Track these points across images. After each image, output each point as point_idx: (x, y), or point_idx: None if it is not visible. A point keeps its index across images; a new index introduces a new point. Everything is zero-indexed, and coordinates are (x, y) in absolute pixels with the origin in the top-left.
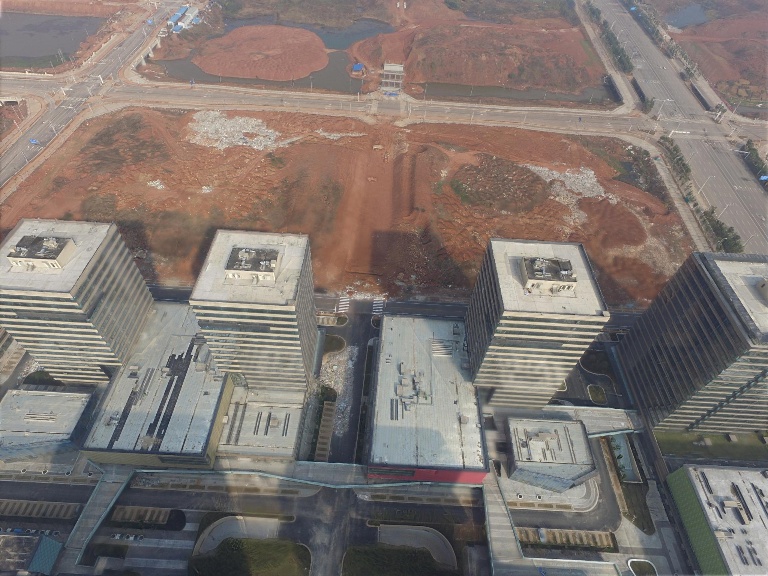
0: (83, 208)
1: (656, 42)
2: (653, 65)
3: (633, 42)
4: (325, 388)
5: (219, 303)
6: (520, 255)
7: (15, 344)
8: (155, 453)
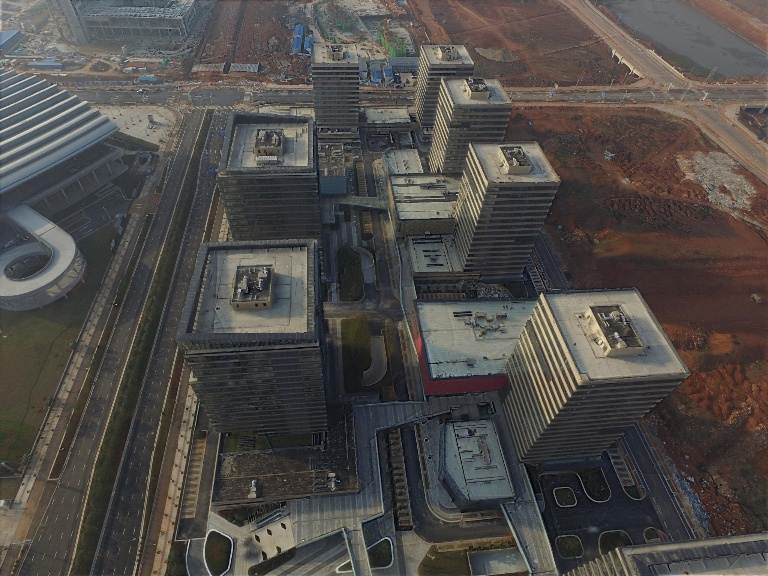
0: (559, 133)
1: None
2: None
3: None
4: (476, 291)
5: None
6: (630, 314)
7: None
8: (394, 201)
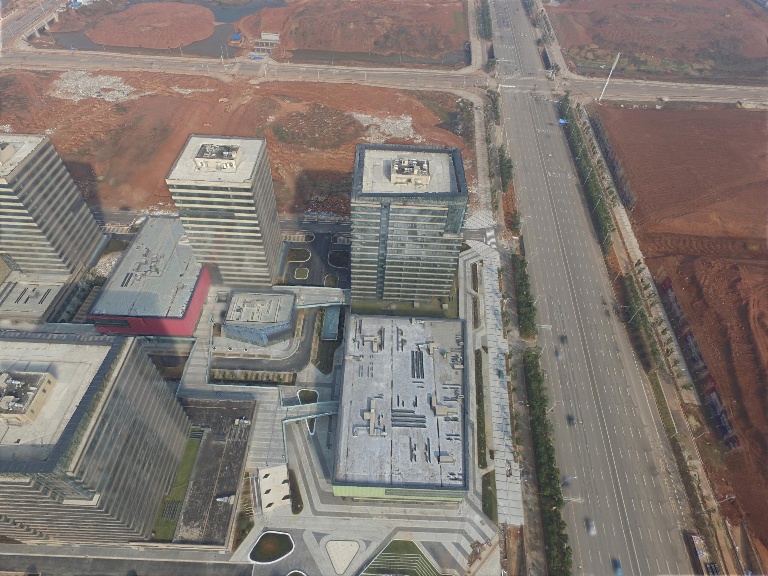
0: None
1: (529, 14)
2: (516, 33)
3: (507, 14)
4: (98, 277)
5: None
6: None
7: None
8: None
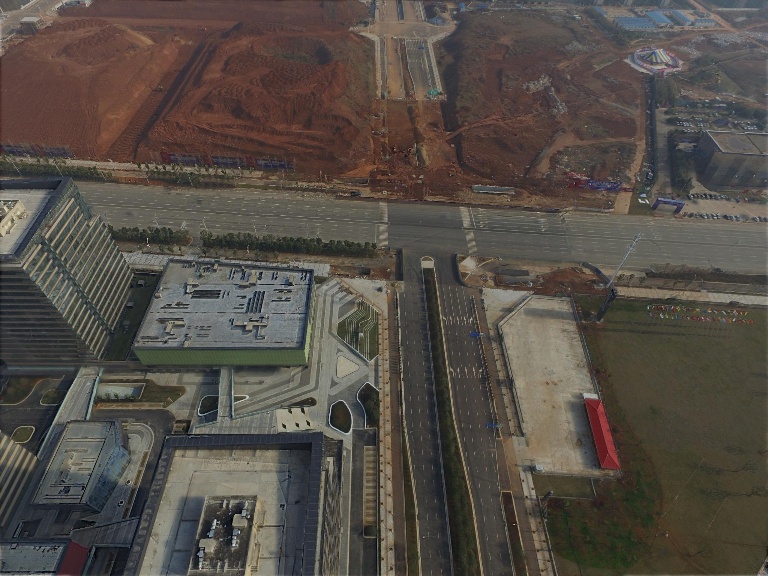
0: None
1: None
2: None
3: None
4: None
5: None
6: None
7: None
8: None
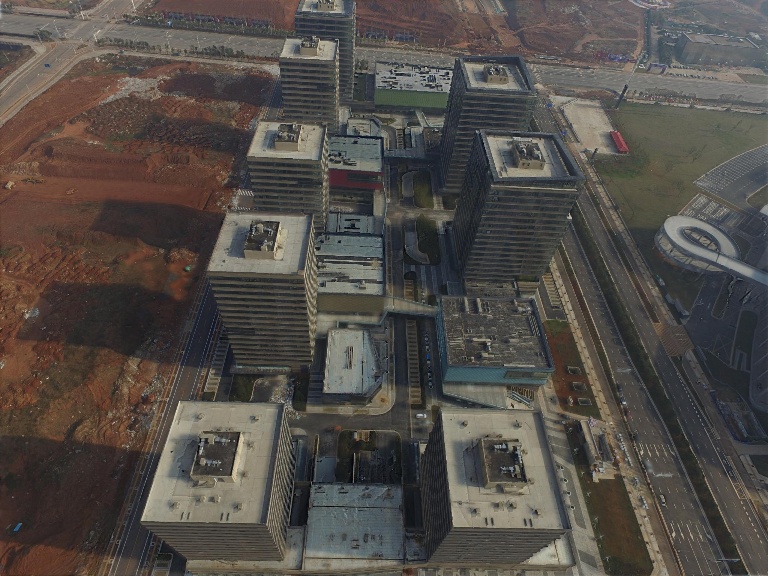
0: (5, 456)
1: None
2: None
3: None
4: None
5: None
6: (292, 53)
7: None
8: None
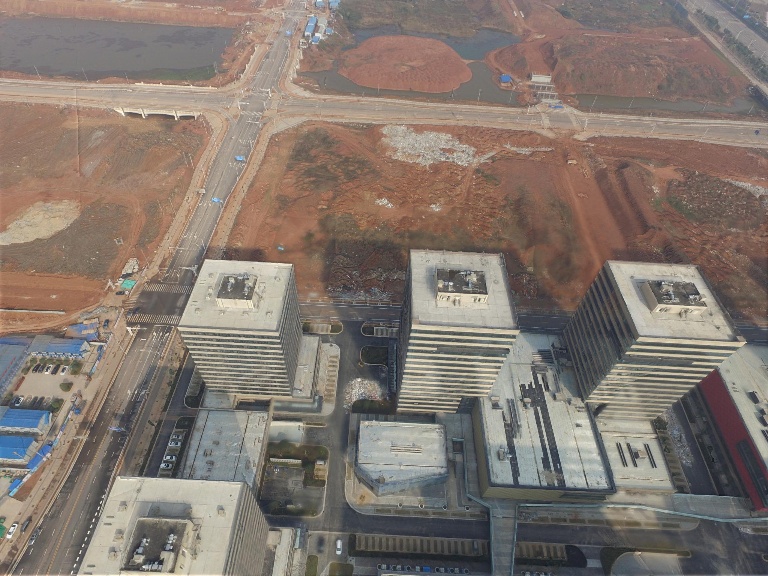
0: (324, 228)
1: None
2: None
3: (761, 51)
4: None
5: (669, 339)
6: None
7: (323, 371)
8: (567, 489)
